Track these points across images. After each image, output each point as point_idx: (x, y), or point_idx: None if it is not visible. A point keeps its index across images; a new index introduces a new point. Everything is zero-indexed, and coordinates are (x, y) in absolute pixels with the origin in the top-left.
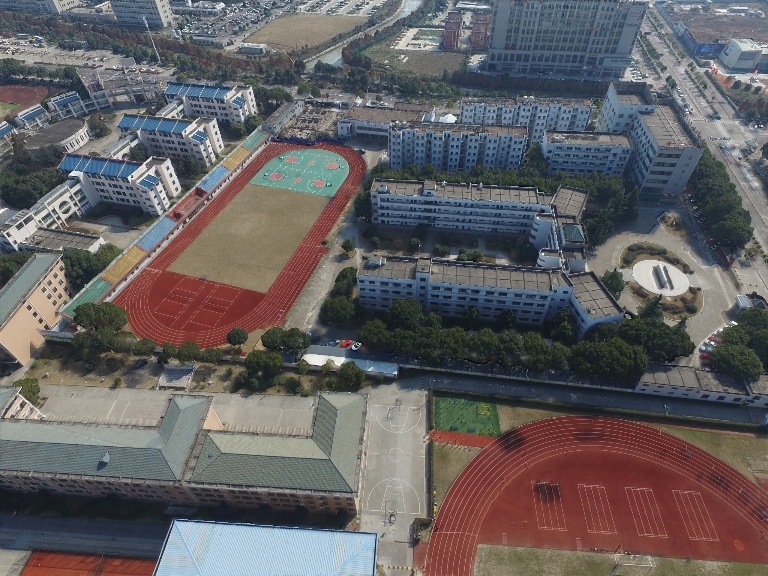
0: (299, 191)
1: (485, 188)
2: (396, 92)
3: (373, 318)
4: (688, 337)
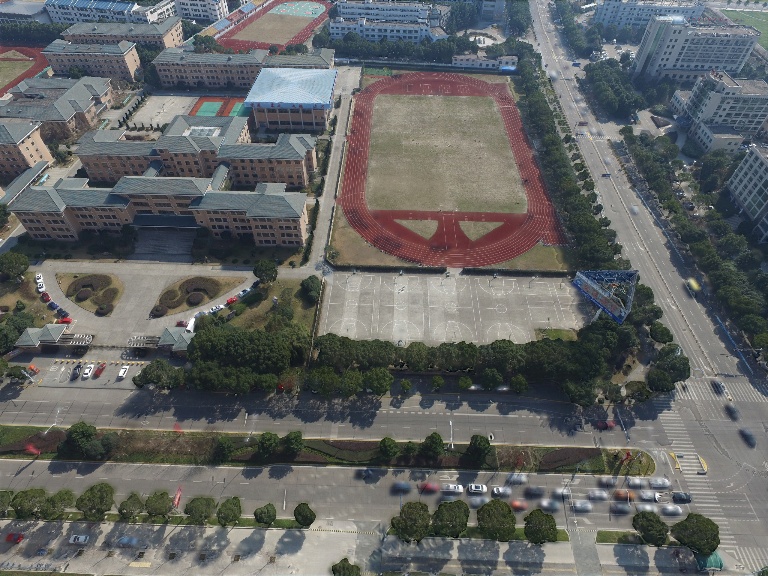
0: (297, 15)
1: (397, 3)
2: None
3: None
4: (476, 43)
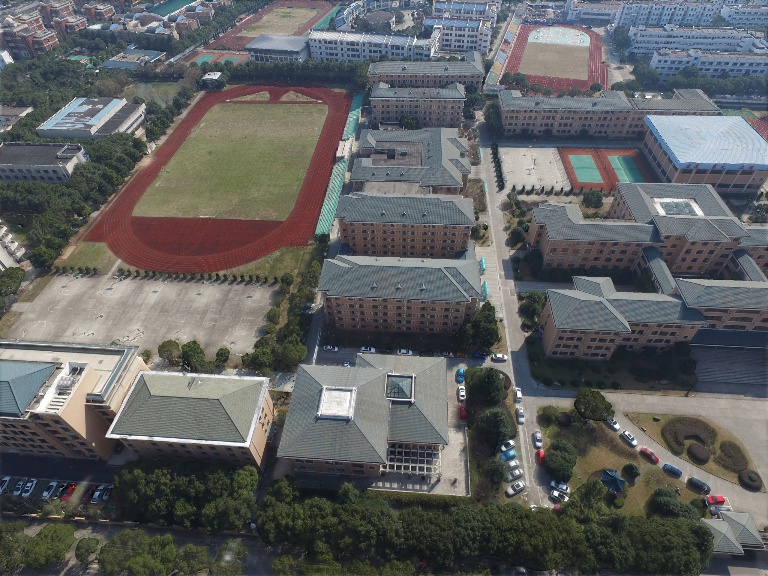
0: (565, 44)
1: (703, 29)
2: (586, 1)
3: (659, 87)
4: None
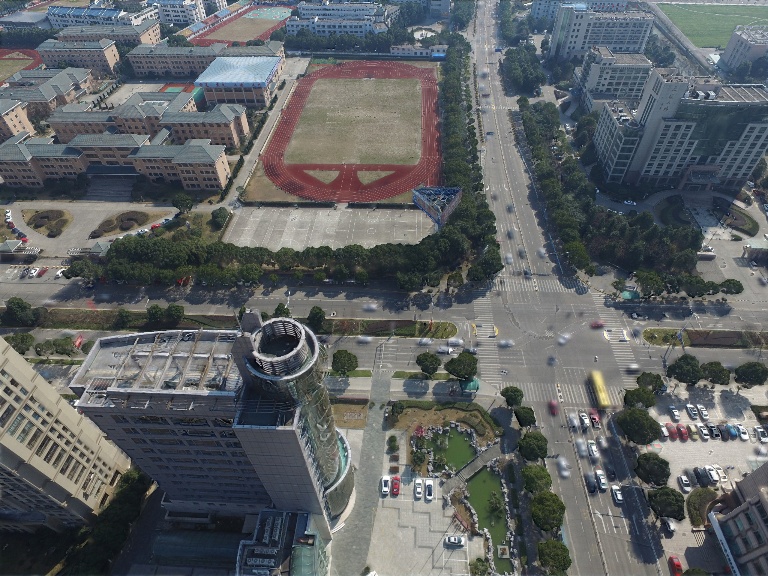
0: (266, 18)
1: (351, 4)
2: None
3: (294, 46)
4: (412, 34)
